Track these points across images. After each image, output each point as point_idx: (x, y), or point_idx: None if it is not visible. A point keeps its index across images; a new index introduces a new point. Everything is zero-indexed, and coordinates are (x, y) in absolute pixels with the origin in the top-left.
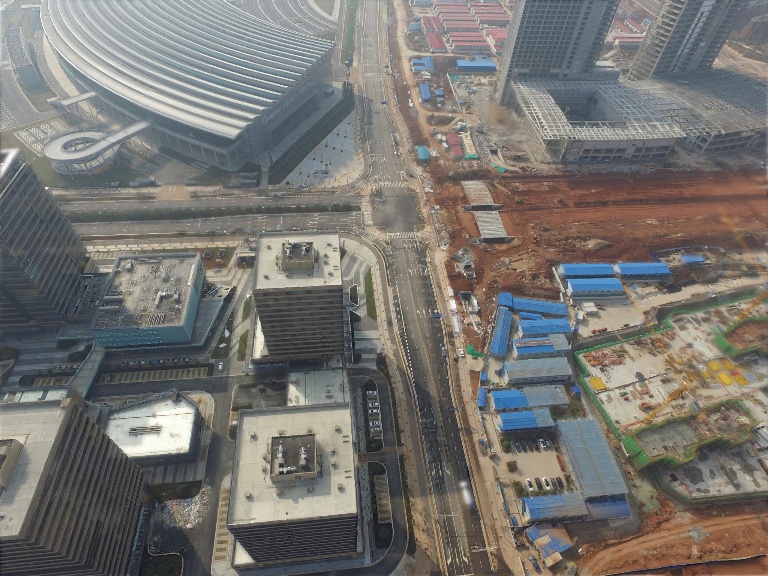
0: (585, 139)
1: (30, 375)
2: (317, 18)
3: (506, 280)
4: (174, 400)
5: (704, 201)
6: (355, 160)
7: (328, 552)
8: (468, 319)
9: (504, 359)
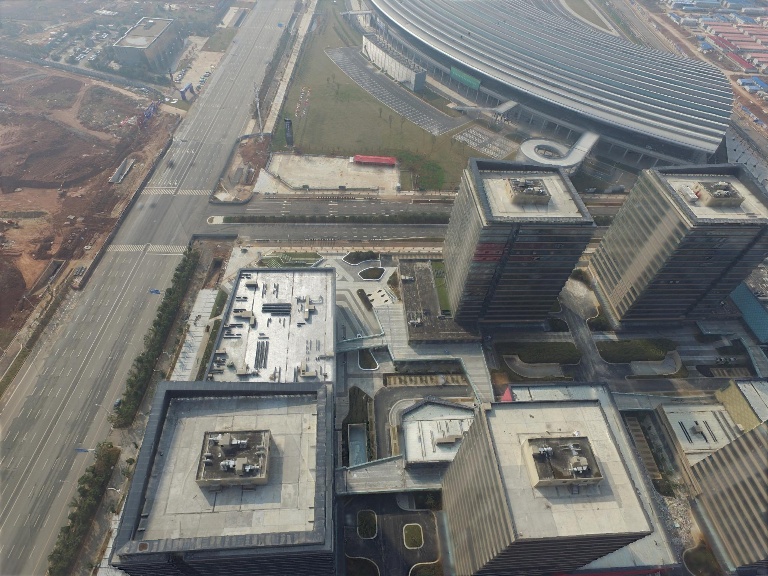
0: None
1: (702, 365)
2: None
3: None
4: None
5: None
6: None
7: None
8: None
9: None
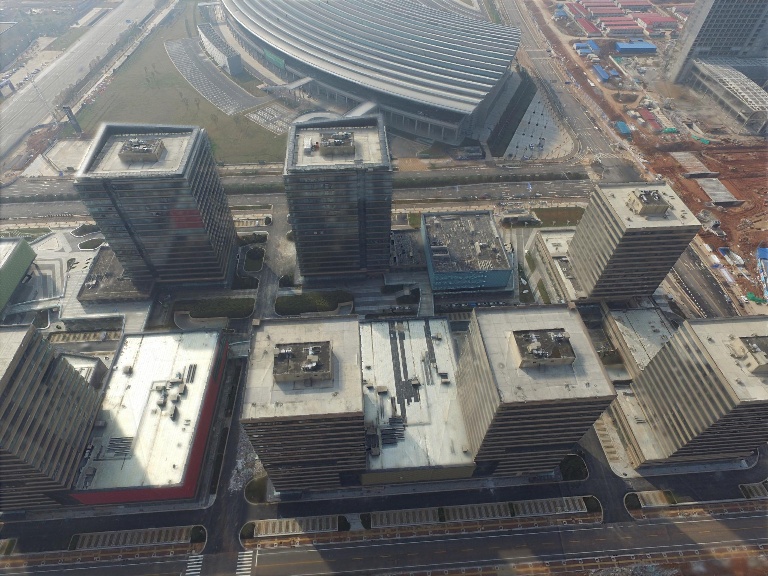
0: None
1: (372, 314)
2: (460, 8)
3: (757, 238)
4: None
5: None
6: (561, 135)
7: (733, 450)
8: (737, 271)
9: None
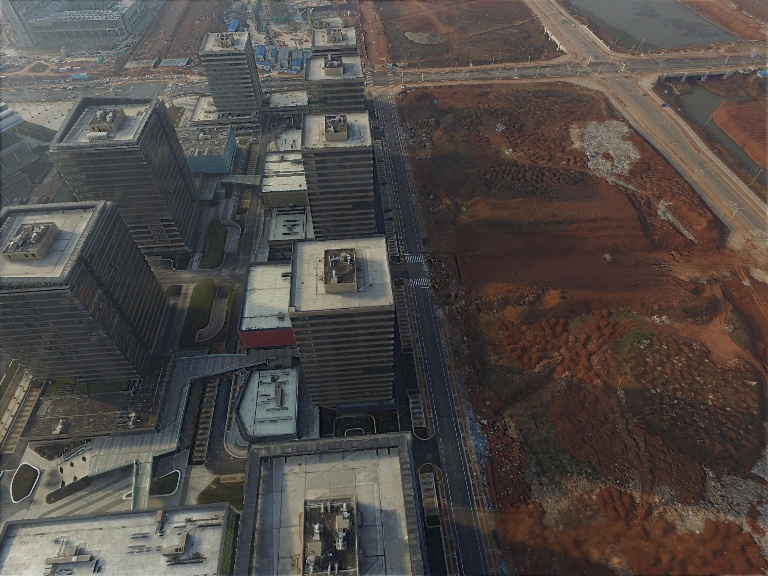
0: (127, 9)
1: None
2: None
3: None
4: None
5: (190, 8)
6: (65, 105)
7: None
8: None
9: (274, 66)
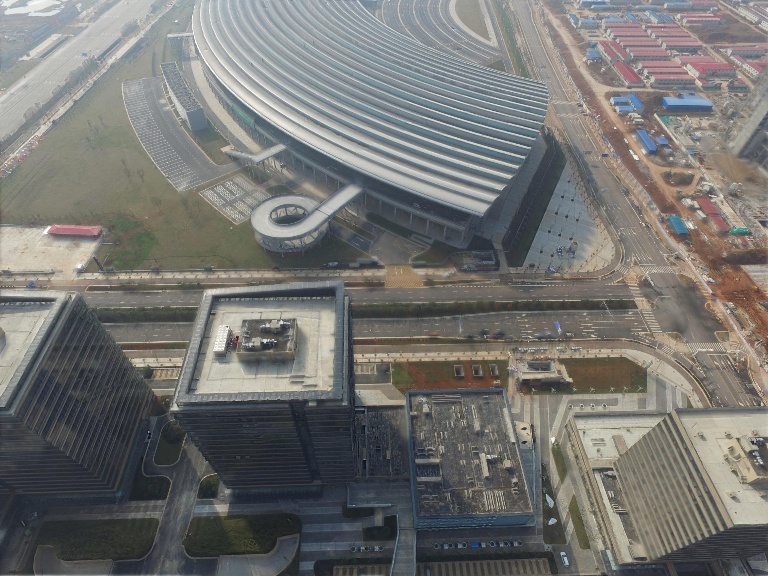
0: None
1: (325, 560)
2: (475, 43)
3: None
4: None
5: None
6: (598, 233)
7: None
8: None
9: None
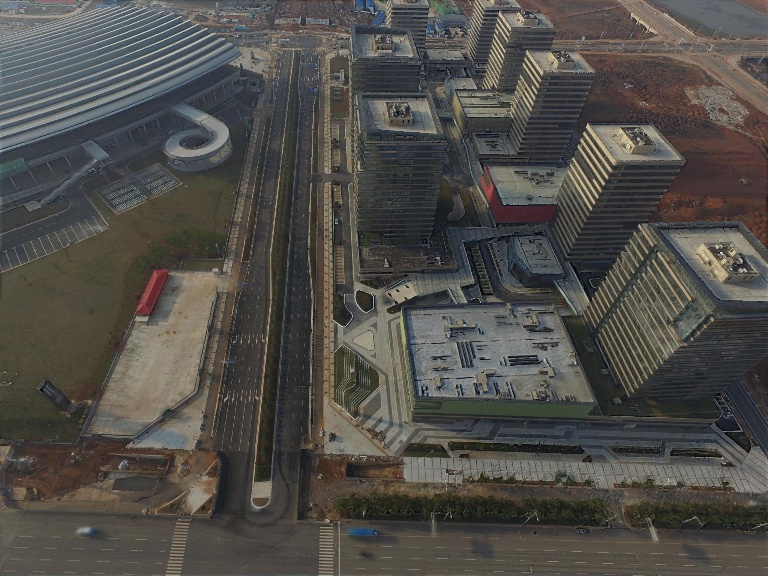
0: None
1: None
2: None
3: (363, 22)
4: (449, 81)
5: None
6: None
7: None
8: None
9: None
